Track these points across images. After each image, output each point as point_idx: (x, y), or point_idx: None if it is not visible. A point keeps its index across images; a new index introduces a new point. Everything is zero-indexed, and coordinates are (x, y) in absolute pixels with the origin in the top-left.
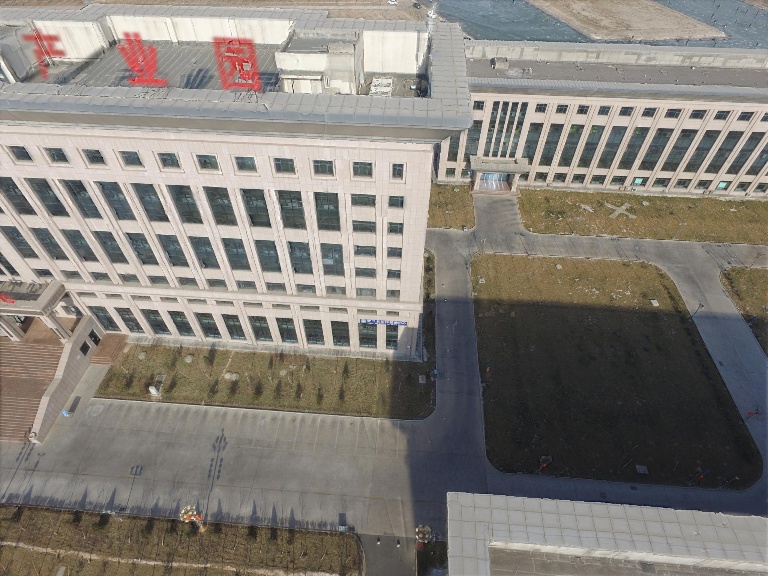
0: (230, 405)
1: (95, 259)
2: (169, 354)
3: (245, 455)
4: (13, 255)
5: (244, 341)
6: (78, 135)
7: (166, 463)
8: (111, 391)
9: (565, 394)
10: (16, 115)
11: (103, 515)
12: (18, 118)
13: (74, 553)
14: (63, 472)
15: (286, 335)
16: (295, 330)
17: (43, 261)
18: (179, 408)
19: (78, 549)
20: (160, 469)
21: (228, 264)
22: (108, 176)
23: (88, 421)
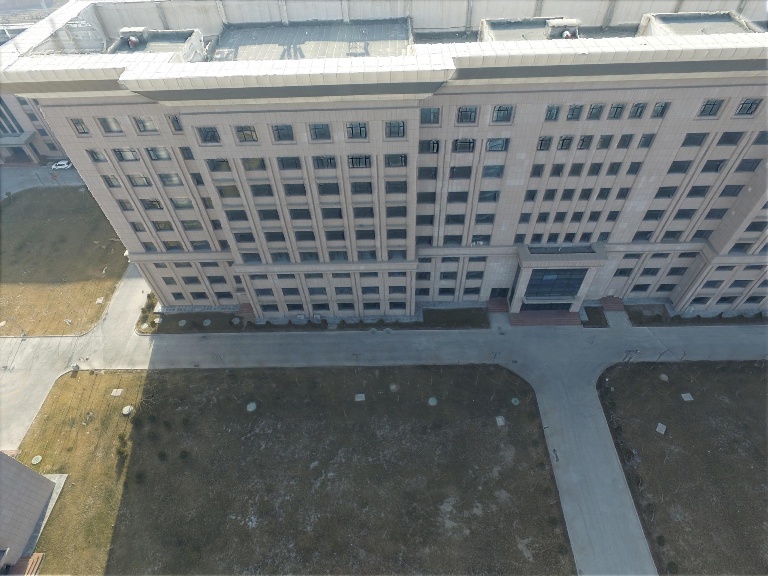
0: None
1: None
2: None
3: None
4: None
5: None
6: None
7: None
8: None
9: (96, 220)
10: None
11: None
12: None
13: None
14: None
15: None
16: None
17: None
18: None
19: None
20: None
21: None
22: None
23: None
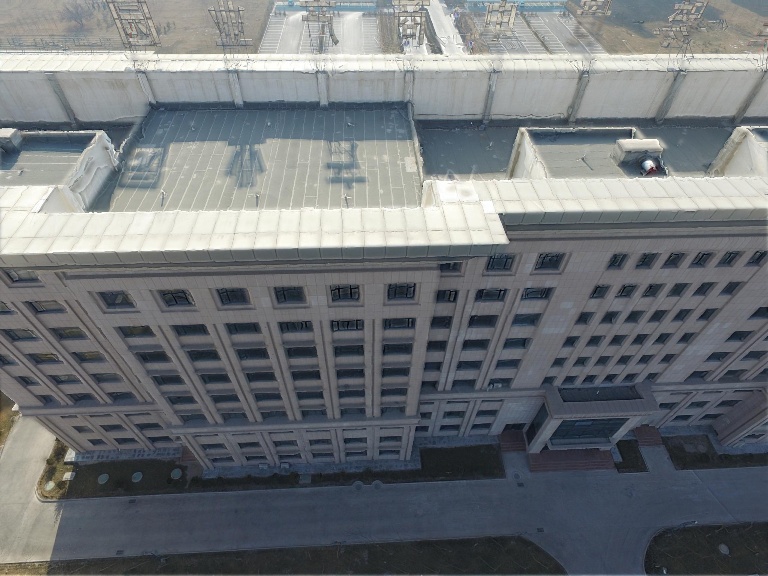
0: None
1: None
2: None
3: None
4: None
5: None
6: None
7: None
8: None
9: None
10: None
11: None
12: None
13: None
14: None
15: None
16: None
17: None
18: None
19: None
20: None
21: None
22: None
23: None
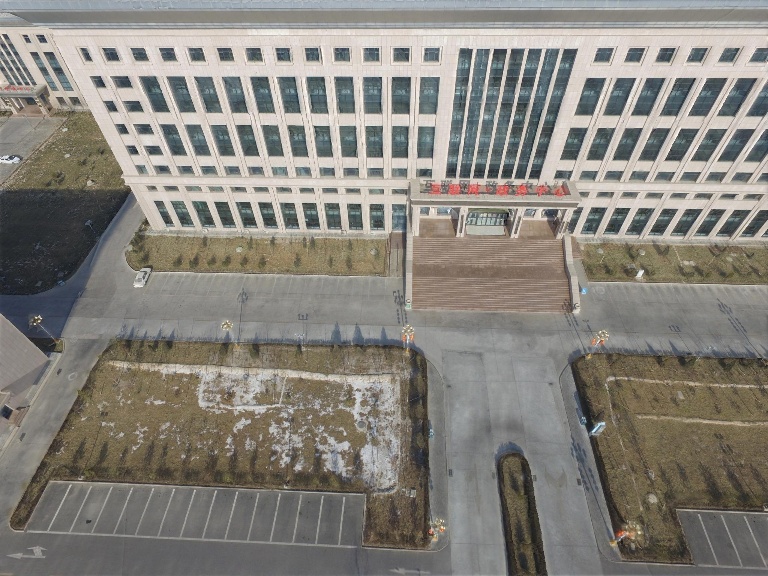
0: (707, 283)
1: (623, 158)
2: (621, 250)
3: (753, 315)
4: (555, 157)
5: (680, 237)
6: (734, 35)
7: (694, 323)
8: (599, 277)
9: None
10: (729, 14)
11: (682, 357)
12: (718, 18)
13: (680, 382)
14: (616, 331)
15: (724, 229)
16: (742, 222)
17: (577, 162)
18: (667, 286)
19: (680, 379)
20: (693, 327)
21: (747, 155)
22: (725, 72)
23: (601, 297)
